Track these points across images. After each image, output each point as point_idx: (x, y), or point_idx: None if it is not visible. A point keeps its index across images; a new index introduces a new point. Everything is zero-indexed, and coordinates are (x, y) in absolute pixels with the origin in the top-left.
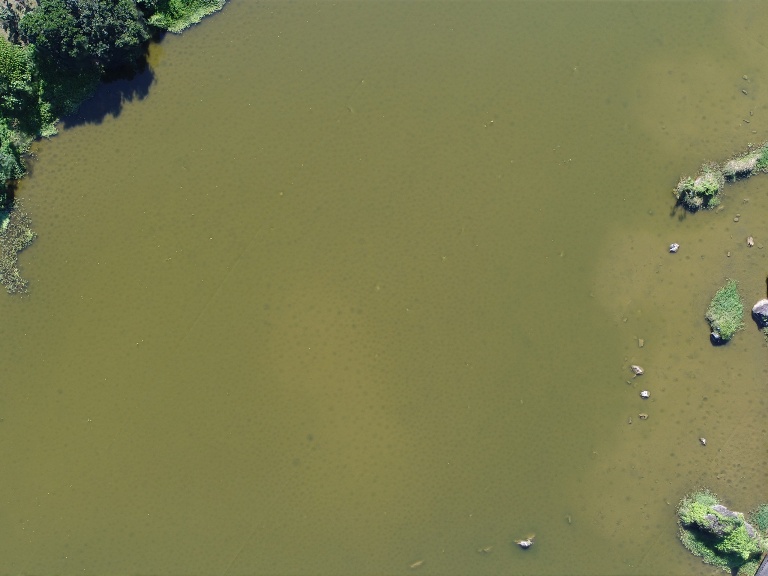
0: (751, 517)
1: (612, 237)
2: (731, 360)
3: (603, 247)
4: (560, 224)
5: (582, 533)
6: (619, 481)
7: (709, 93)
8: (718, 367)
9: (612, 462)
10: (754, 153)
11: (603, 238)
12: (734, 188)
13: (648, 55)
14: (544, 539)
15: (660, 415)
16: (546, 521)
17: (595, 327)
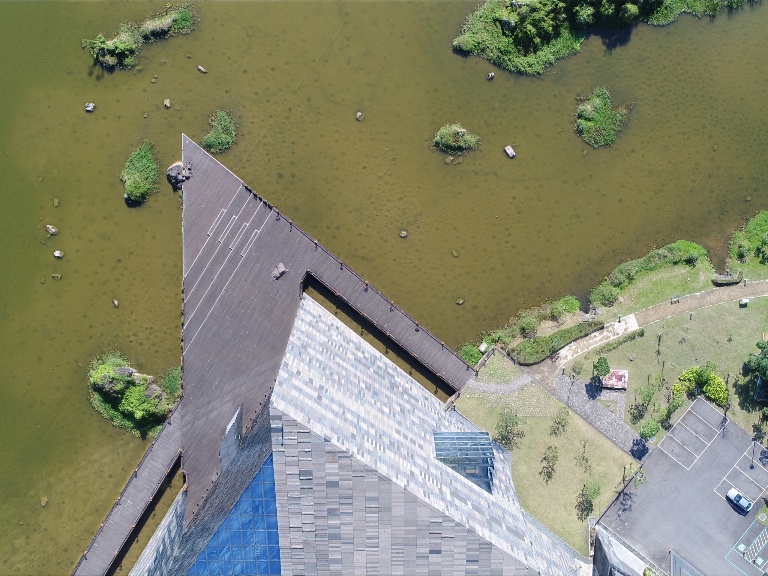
0: (161, 381)
1: (29, 95)
2: (146, 222)
3: (20, 105)
4: None
5: None
6: (31, 341)
7: None
8: (133, 229)
9: (25, 322)
10: (172, 14)
11: (20, 96)
12: (153, 49)
13: None
14: None
15: (73, 276)
16: None
17: (10, 185)
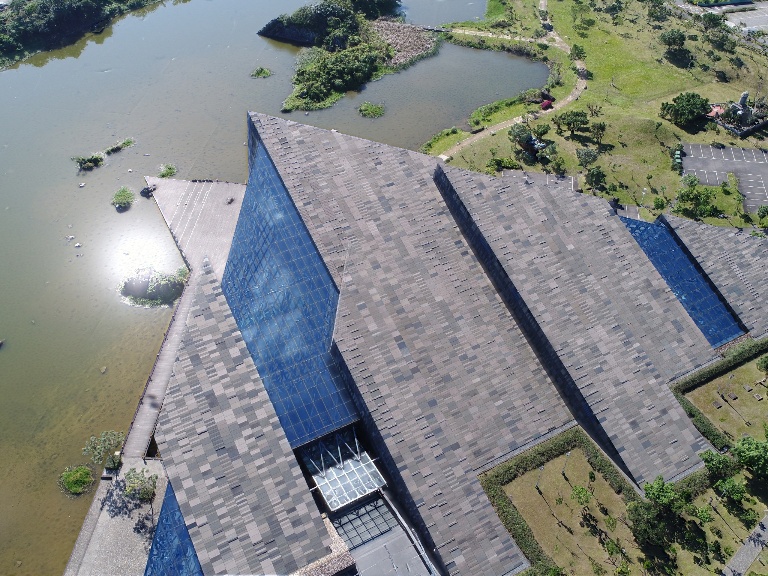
0: None
1: (40, 193)
2: (134, 216)
3: (35, 198)
4: (4, 198)
5: (45, 326)
6: (69, 290)
7: (89, 133)
8: (126, 221)
9: (62, 283)
10: None
11: (34, 195)
12: (114, 157)
13: (49, 131)
14: (14, 339)
15: (92, 251)
16: (14, 329)
17: (36, 229)
